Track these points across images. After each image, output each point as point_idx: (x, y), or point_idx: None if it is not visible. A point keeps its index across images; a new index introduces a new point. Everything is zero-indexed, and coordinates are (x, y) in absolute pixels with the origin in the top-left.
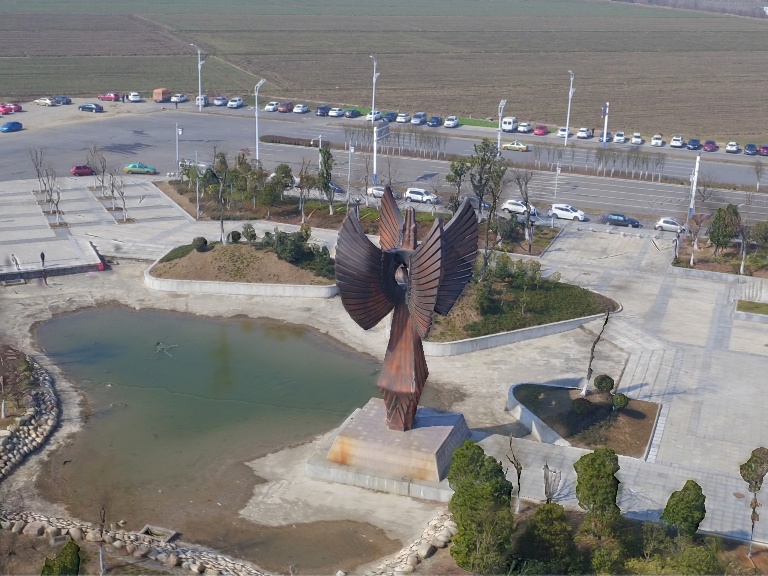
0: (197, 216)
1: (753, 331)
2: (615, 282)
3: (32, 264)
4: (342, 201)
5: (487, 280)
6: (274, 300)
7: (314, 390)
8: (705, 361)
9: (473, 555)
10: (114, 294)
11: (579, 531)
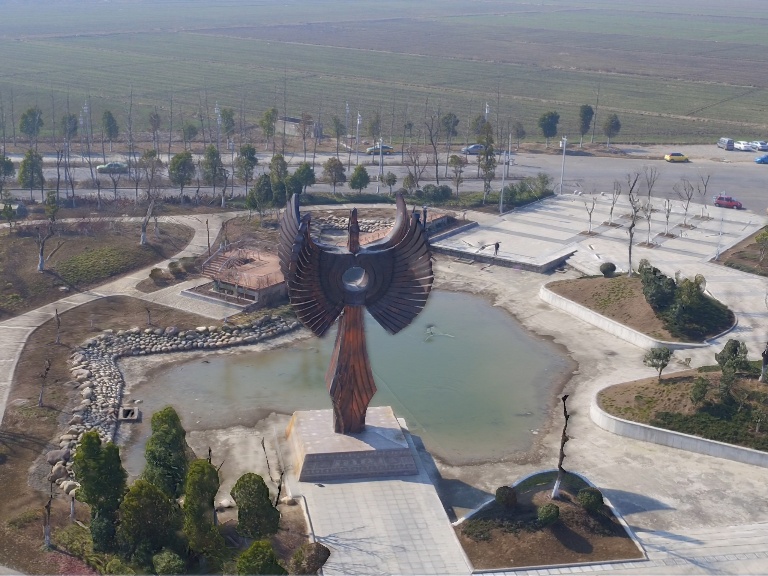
0: (716, 258)
1: None
2: None
3: None
4: None
5: (767, 382)
6: (605, 337)
7: (452, 403)
8: None
9: None
10: (506, 290)
11: None
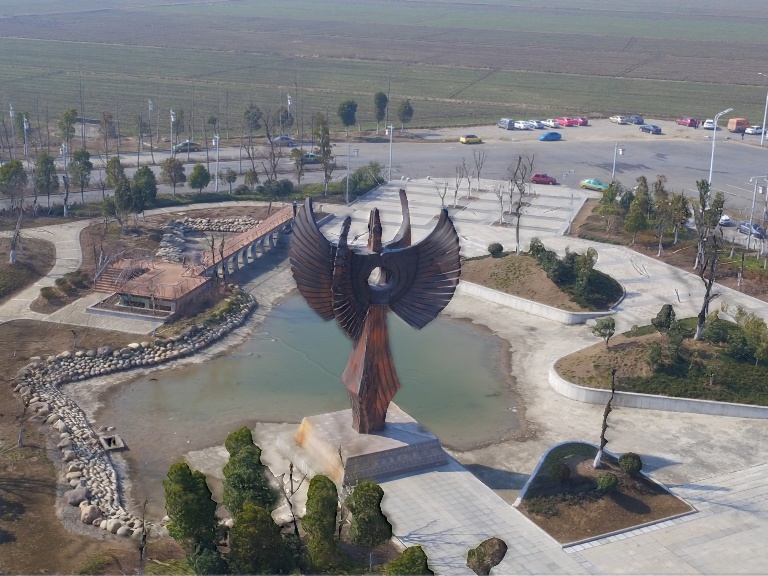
0: (568, 231)
1: None
2: None
3: None
4: (742, 245)
5: (703, 340)
6: (517, 314)
7: (419, 392)
8: None
9: None
10: None
11: (367, 569)
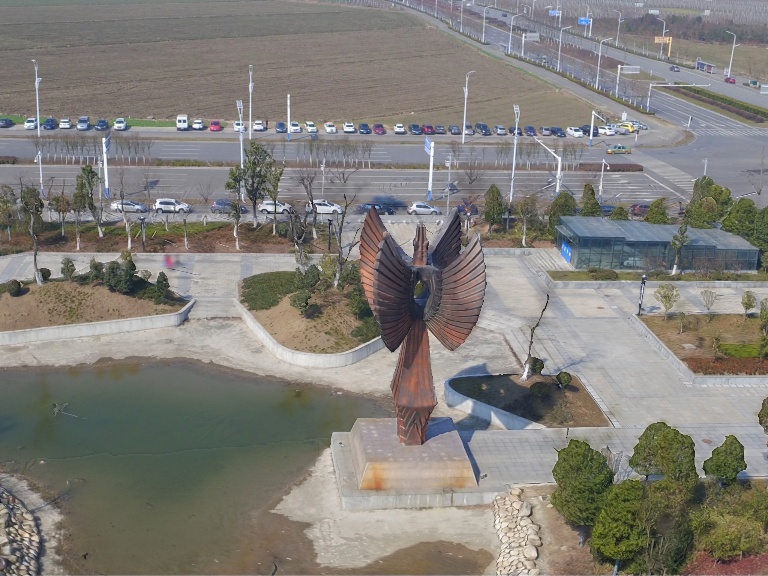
0: None
1: (577, 297)
2: None
3: None
4: None
5: None
6: (124, 337)
7: (255, 423)
8: (569, 330)
9: (624, 543)
10: None
11: None
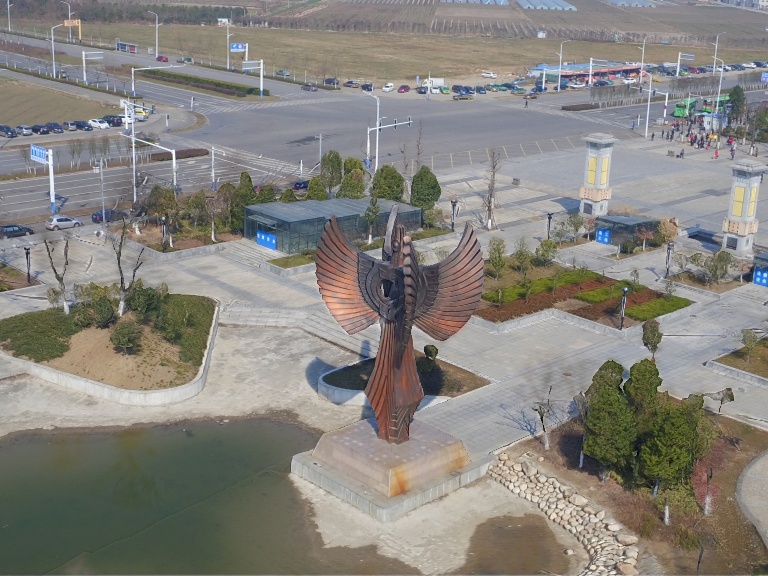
0: None
1: (315, 280)
2: (152, 282)
3: None
4: None
5: (126, 312)
6: None
7: (184, 474)
8: None
9: (677, 463)
10: None
11: None
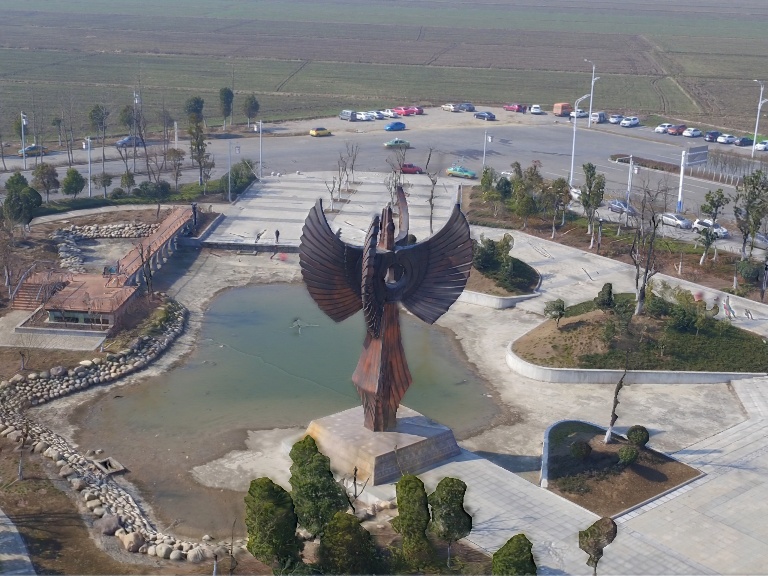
0: None
1: None
2: None
3: (271, 239)
4: (620, 223)
5: (644, 314)
6: None
7: None
8: None
9: None
10: None
11: None
